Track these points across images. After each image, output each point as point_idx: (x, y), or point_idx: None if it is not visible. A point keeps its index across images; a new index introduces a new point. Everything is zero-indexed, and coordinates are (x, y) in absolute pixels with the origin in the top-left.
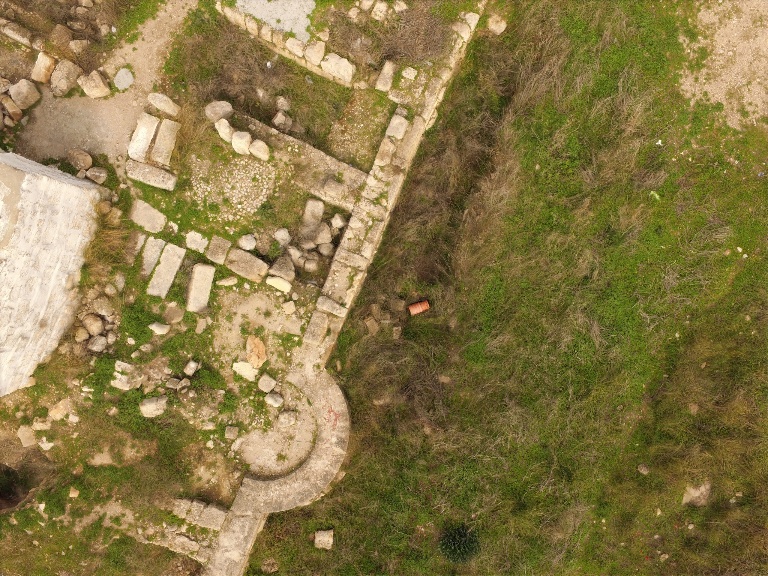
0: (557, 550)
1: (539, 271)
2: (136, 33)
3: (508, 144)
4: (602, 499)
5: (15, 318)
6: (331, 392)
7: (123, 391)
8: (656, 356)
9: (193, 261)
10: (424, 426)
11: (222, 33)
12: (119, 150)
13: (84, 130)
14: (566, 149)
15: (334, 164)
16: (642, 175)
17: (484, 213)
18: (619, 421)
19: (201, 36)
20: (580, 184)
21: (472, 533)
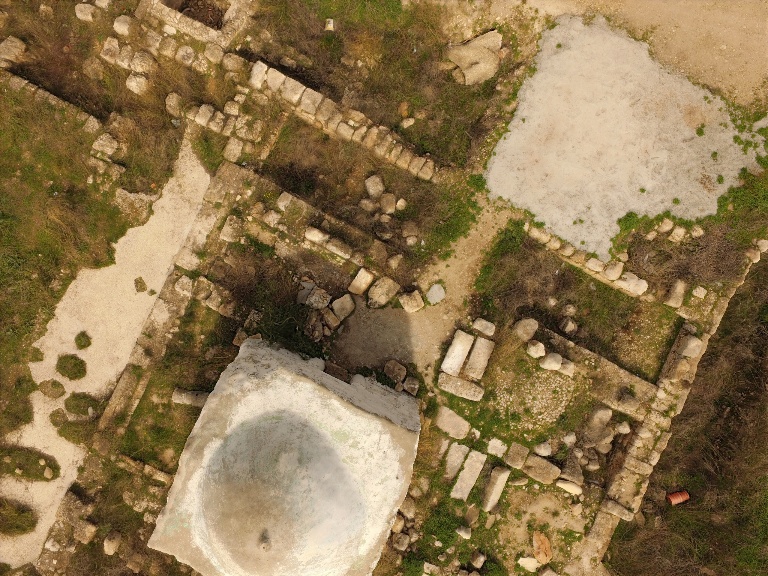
0: None
1: None
2: (449, 251)
3: None
4: None
5: None
6: None
7: None
8: None
9: (491, 464)
10: None
11: (529, 252)
12: (427, 360)
13: (396, 340)
14: None
15: (627, 377)
16: None
17: (764, 426)
18: None
19: (517, 261)
20: None
21: None
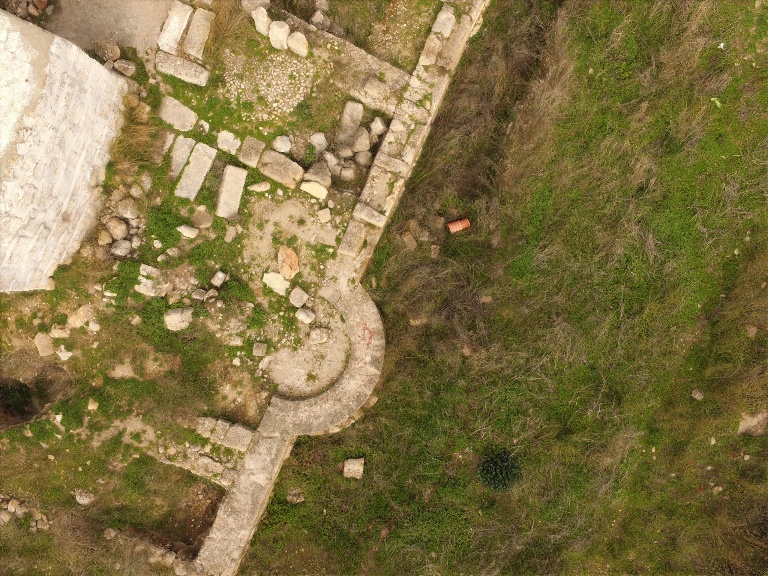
0: (604, 479)
1: (592, 179)
2: None
3: (559, 47)
4: (653, 426)
5: (38, 200)
6: (366, 308)
7: (147, 298)
8: (713, 275)
9: (224, 163)
10: (463, 347)
11: None
12: (148, 43)
13: (112, 21)
14: (622, 51)
15: (375, 63)
16: (703, 79)
17: (533, 119)
18: (673, 342)
19: None
20: (636, 89)
21: (514, 458)
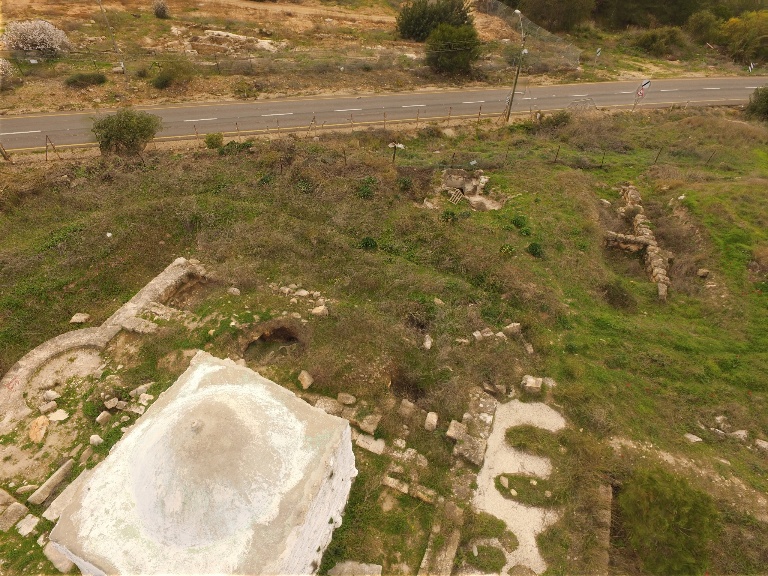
0: None
1: None
2: None
3: None
4: None
5: None
6: (1, 402)
7: None
8: None
9: None
10: None
11: None
12: None
13: None
14: None
15: None
16: None
17: None
18: None
19: None
20: None
21: None
